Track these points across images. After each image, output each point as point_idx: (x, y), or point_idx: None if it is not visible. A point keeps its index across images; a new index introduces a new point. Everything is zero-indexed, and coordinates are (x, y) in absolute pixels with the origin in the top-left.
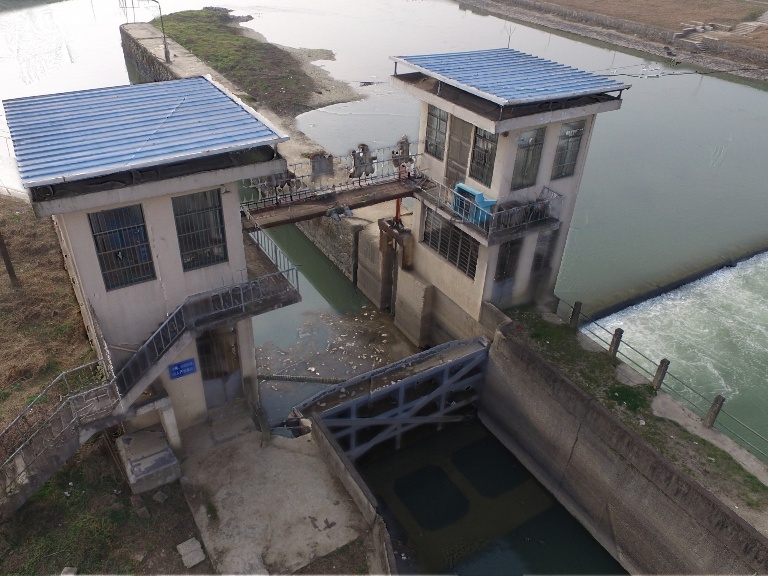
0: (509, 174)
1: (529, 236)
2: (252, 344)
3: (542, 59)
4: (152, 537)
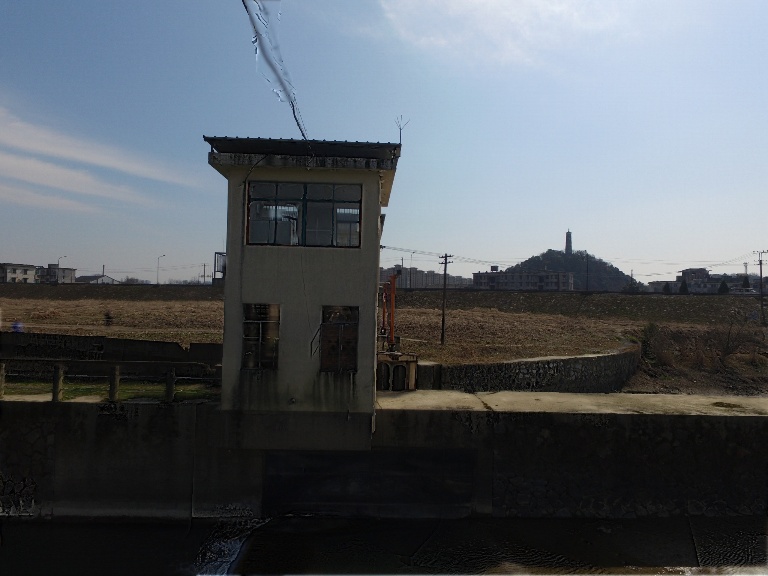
0: None
1: None
2: None
3: None
4: None
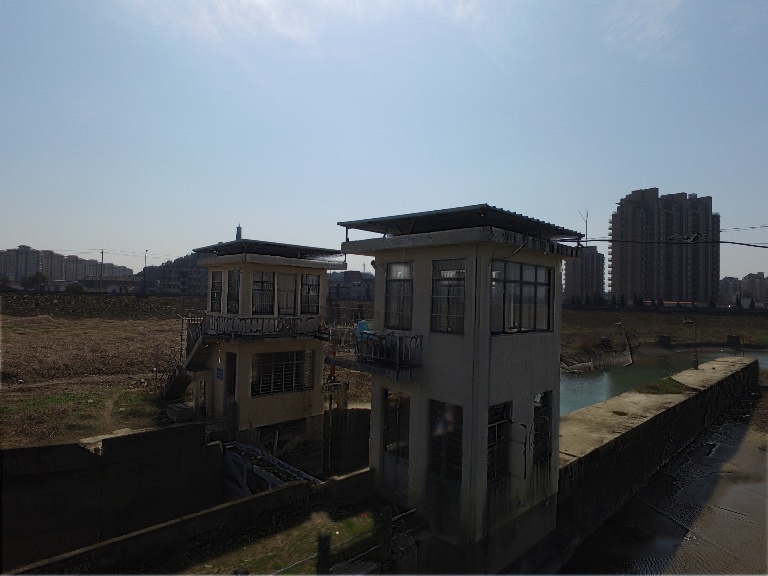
0: (381, 307)
1: (415, 403)
2: (240, 379)
3: None
4: (137, 422)
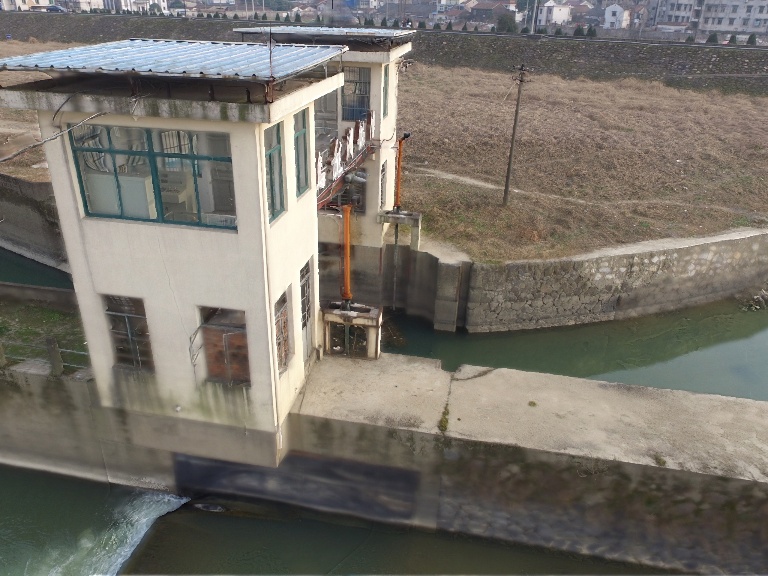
0: None
1: None
2: None
3: (169, 70)
4: None
